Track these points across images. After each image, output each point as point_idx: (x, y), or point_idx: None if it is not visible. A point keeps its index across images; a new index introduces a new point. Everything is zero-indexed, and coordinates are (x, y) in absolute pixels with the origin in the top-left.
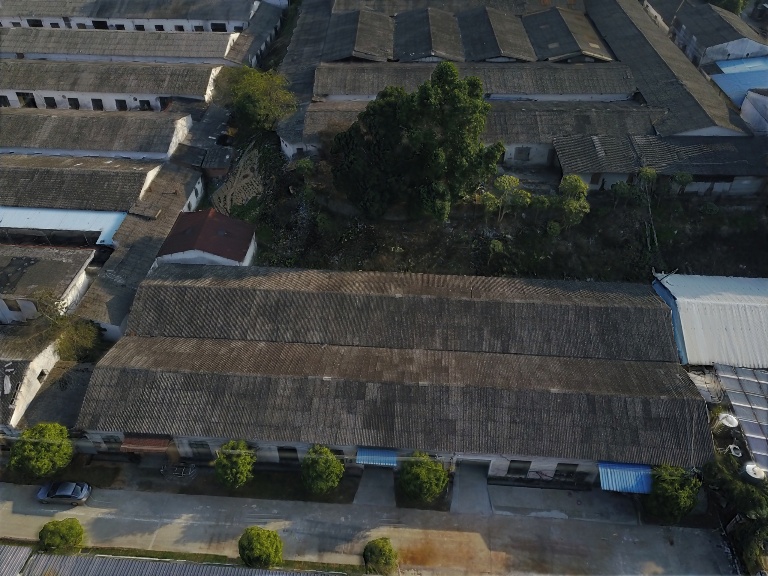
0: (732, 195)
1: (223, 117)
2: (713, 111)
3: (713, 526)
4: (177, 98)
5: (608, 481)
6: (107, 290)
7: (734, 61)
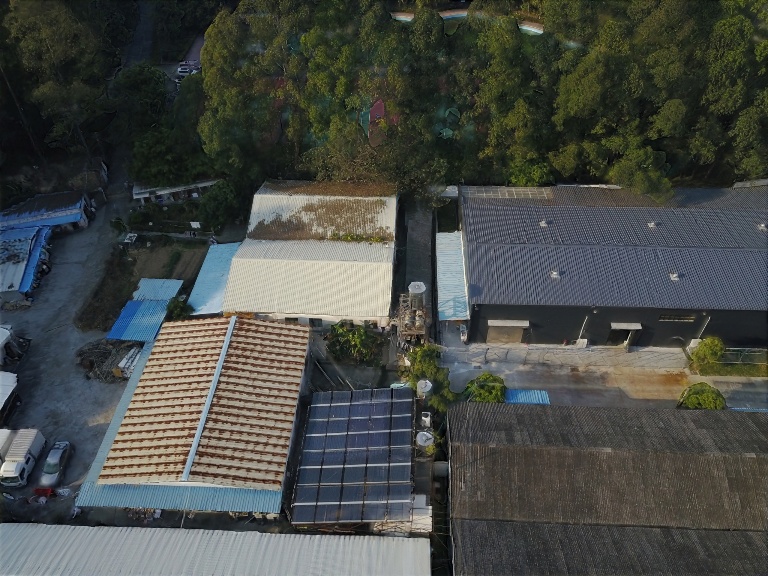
0: None
1: None
2: None
3: None
4: None
5: (542, 396)
6: None
7: None
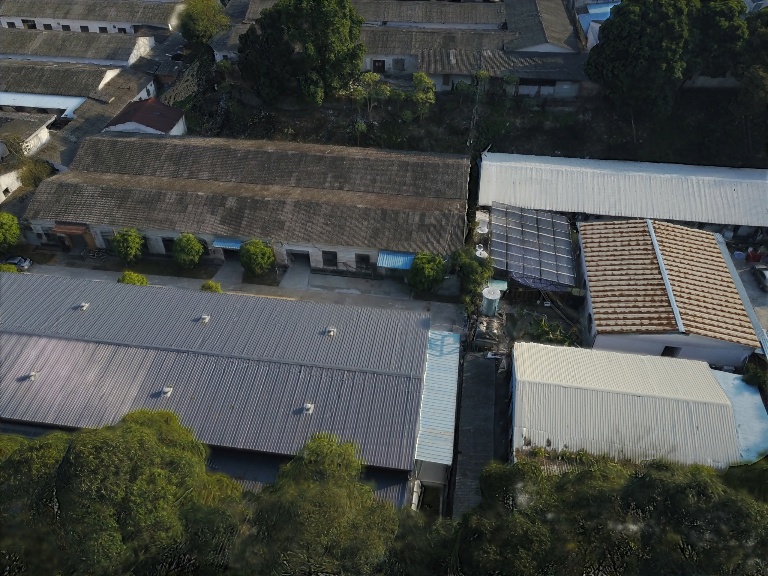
0: (556, 98)
1: (182, 42)
2: (553, 34)
3: (462, 302)
4: (147, 26)
5: (383, 261)
6: (62, 143)
7: (602, 5)
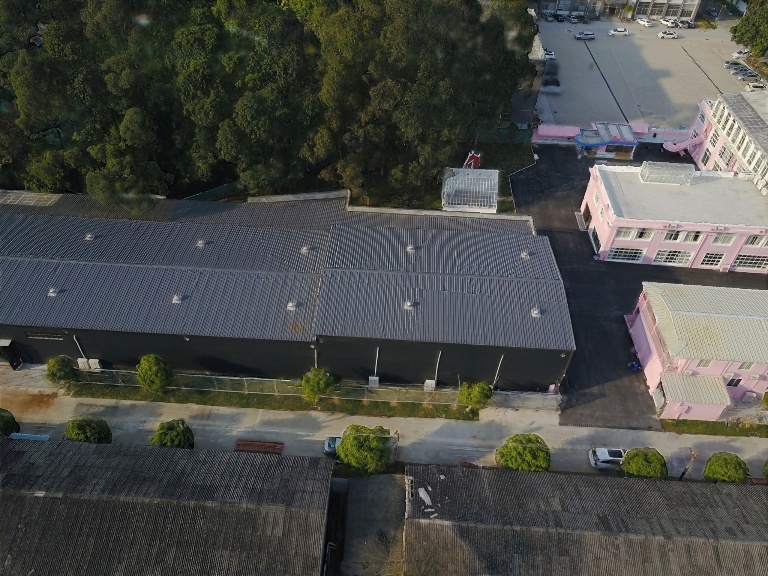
0: None
1: None
2: None
3: None
4: None
5: None
6: None
7: None
